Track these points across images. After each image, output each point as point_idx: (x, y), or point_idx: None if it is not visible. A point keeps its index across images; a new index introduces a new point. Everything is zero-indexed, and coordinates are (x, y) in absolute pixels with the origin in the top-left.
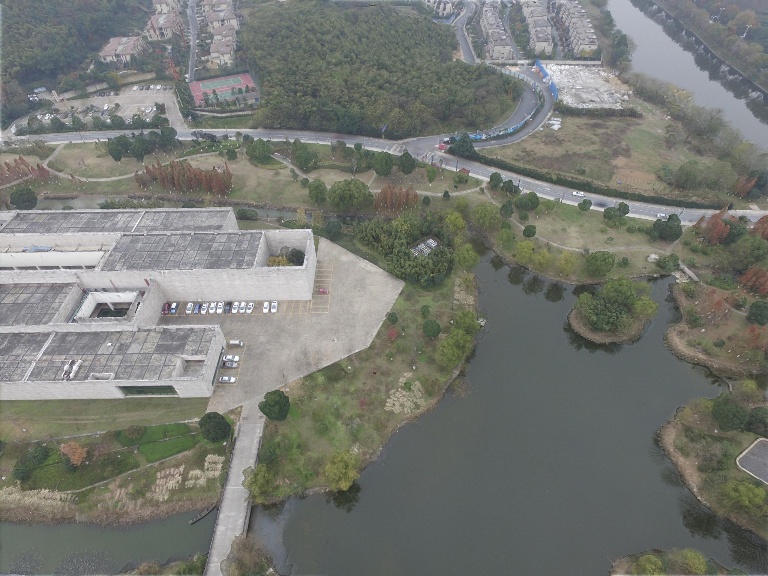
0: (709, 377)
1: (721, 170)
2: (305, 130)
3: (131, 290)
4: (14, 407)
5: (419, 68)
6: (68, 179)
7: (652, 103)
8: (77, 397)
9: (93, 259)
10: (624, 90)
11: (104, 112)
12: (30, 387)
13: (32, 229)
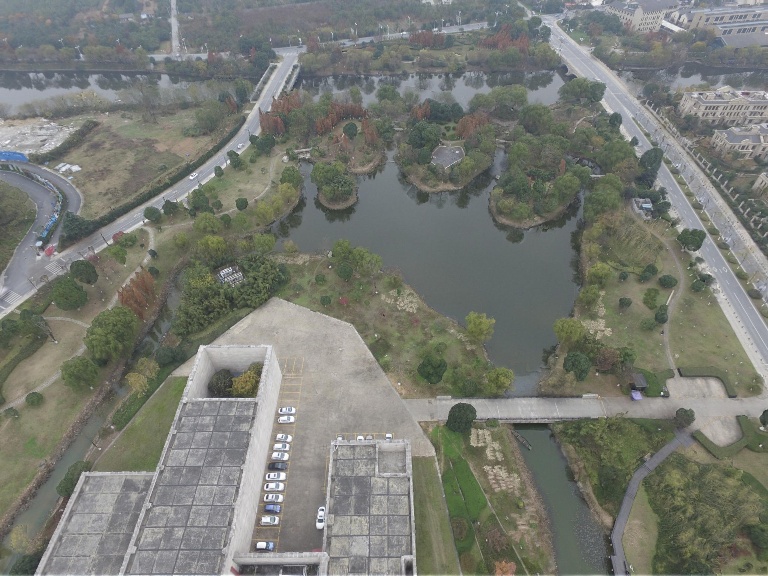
0: (371, 178)
1: (214, 104)
2: None
3: None
4: None
5: None
6: None
7: (75, 115)
8: None
9: None
10: (37, 122)
11: None
12: None
13: None
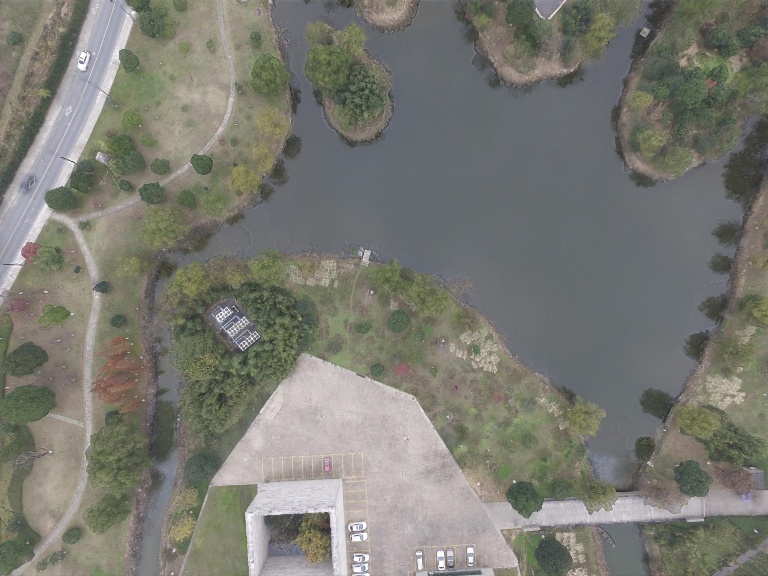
0: None
1: None
2: None
3: None
4: None
5: None
6: None
7: None
8: None
9: None
10: None
11: None
12: None
13: None
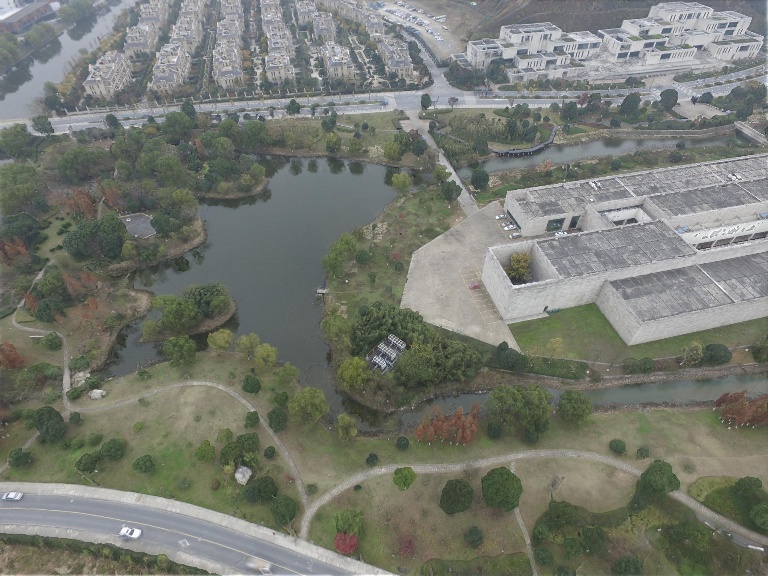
0: None
1: None
2: None
3: None
4: None
5: None
6: None
7: None
8: None
9: None
10: None
11: None
12: None
13: None
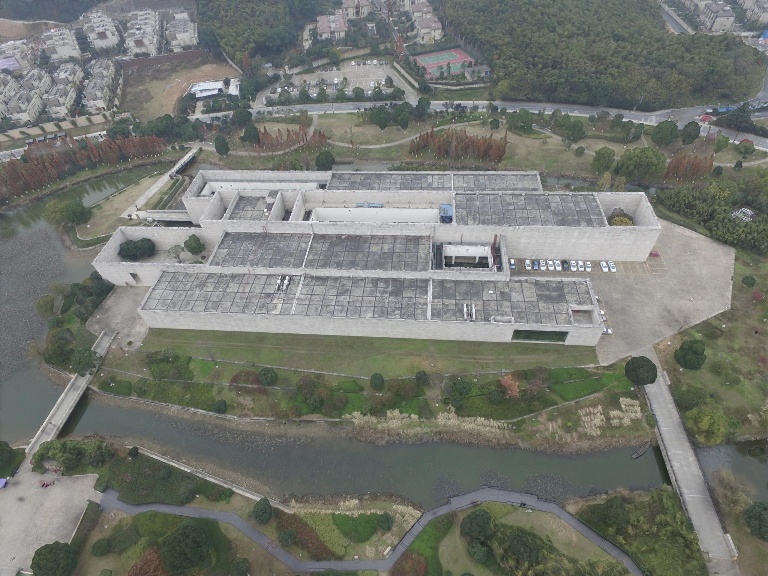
0: None
1: None
2: (546, 102)
3: (474, 245)
4: (410, 344)
5: (659, 39)
6: (339, 146)
7: None
8: (467, 339)
9: (422, 216)
10: None
11: (336, 85)
12: (434, 326)
13: (355, 187)
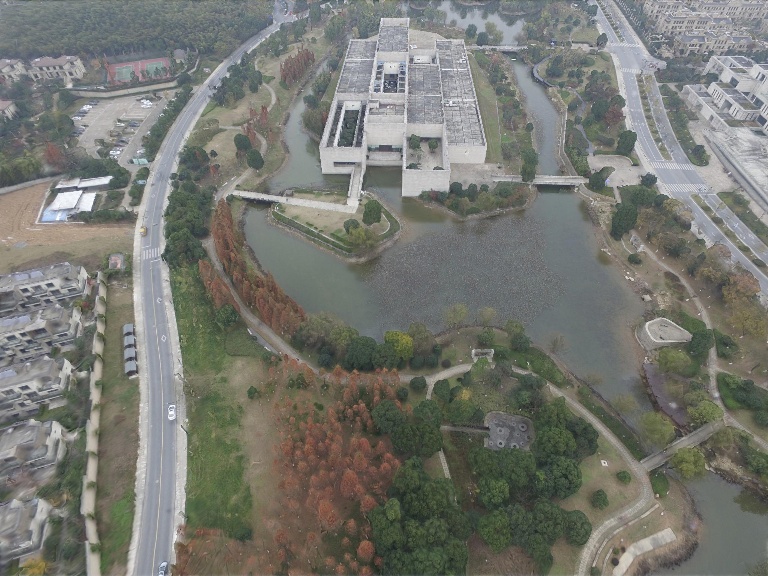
0: None
1: None
2: (239, 46)
3: None
4: None
5: None
6: None
7: None
8: None
9: None
10: None
11: None
12: None
13: (357, 86)
